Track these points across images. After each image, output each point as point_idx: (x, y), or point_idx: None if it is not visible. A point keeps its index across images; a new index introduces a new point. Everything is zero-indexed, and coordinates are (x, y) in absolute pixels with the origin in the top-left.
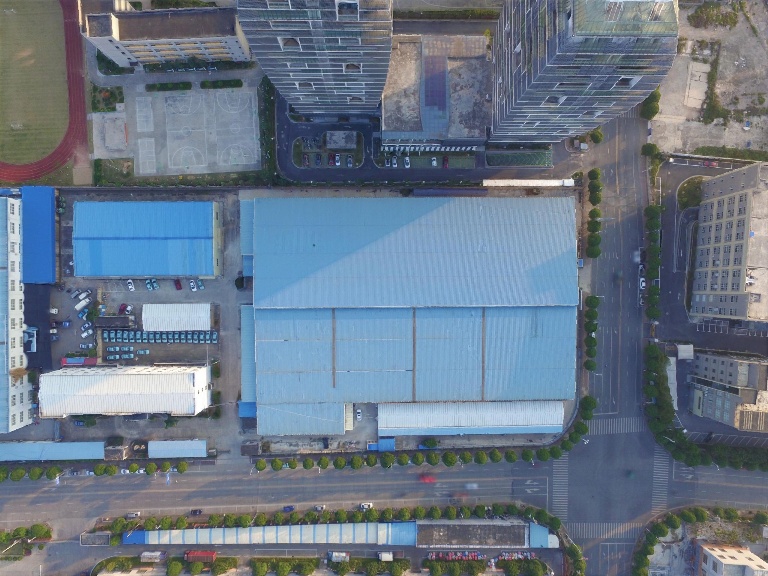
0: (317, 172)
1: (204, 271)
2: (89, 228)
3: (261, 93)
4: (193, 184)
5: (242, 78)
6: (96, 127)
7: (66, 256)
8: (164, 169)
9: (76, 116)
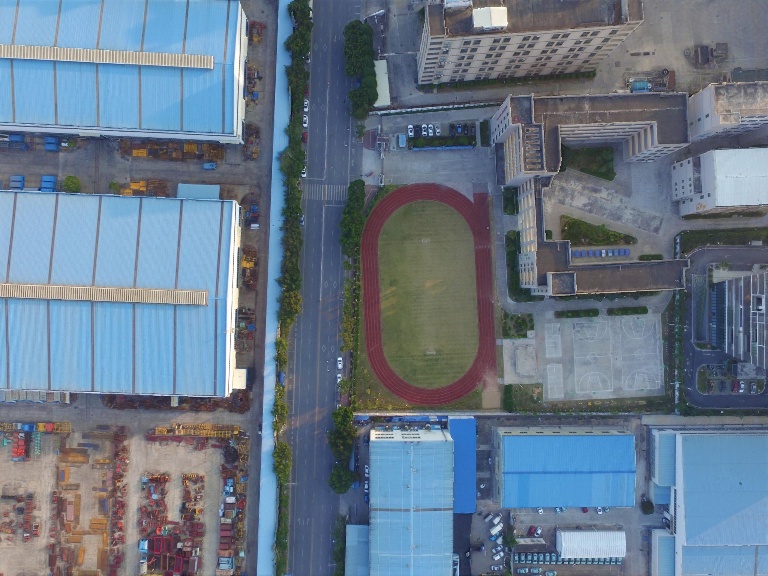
0: (720, 398)
1: (625, 503)
2: (518, 462)
3: (665, 320)
4: (601, 410)
5: (647, 305)
6: (506, 353)
7: (477, 479)
8: (572, 394)
9: (485, 341)
